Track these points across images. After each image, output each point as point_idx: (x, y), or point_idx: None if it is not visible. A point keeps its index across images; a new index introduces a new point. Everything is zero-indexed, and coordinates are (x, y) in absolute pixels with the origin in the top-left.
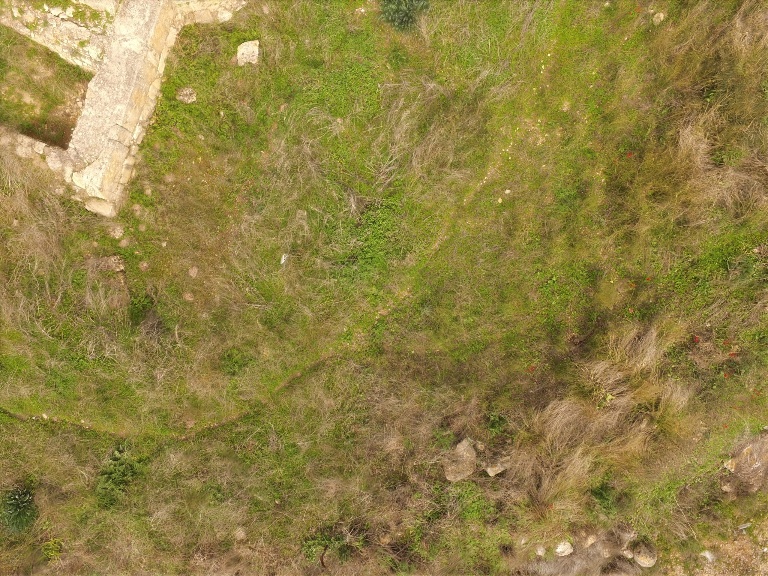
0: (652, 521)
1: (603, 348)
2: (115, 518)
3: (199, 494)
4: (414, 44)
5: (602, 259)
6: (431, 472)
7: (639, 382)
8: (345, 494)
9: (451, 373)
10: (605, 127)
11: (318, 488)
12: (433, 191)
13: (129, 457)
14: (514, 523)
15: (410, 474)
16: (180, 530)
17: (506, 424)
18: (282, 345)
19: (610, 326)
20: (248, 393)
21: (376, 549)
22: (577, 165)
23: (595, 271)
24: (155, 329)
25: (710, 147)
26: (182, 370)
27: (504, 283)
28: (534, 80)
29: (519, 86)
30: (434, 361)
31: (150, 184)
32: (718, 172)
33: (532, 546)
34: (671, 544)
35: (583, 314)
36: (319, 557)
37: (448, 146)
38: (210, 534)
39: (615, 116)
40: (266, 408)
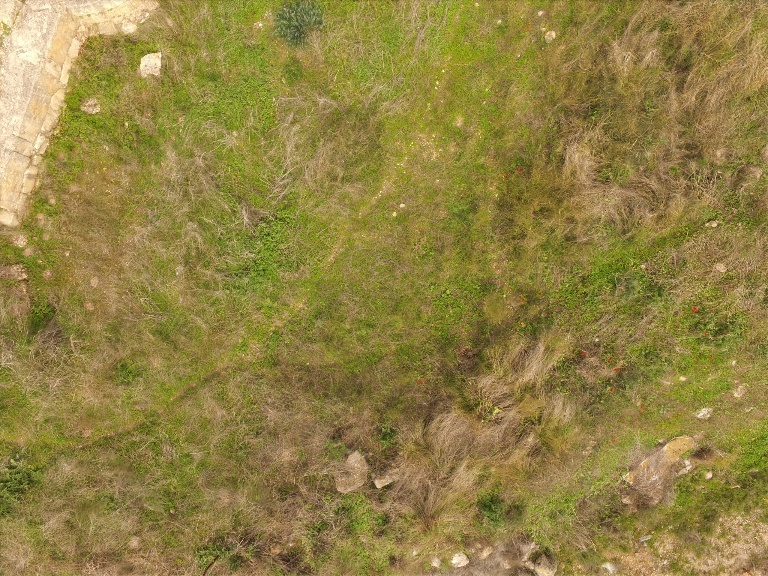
0: (553, 533)
1: (489, 362)
2: (11, 526)
3: (93, 503)
4: (309, 59)
5: (495, 273)
6: (323, 483)
7: (522, 396)
8: (233, 505)
9: (345, 385)
10: (497, 143)
11: (210, 498)
12: (326, 204)
13: (25, 465)
14: (400, 535)
15: (301, 485)
16: (70, 539)
17: (397, 436)
18: (177, 356)
19: (499, 340)
20: (143, 403)
21: (265, 560)
22: (470, 180)
23: (488, 285)
24: (52, 338)
25: (597, 164)
26: (79, 379)
27: (398, 296)
28: (428, 96)
29: (413, 101)
30: (328, 373)
31: (54, 194)
32: (604, 189)
33: (426, 557)
34: (572, 556)
35: (476, 327)
36: (210, 567)
37: (336, 161)
38: (104, 543)
39: (505, 132)
40: (161, 418)
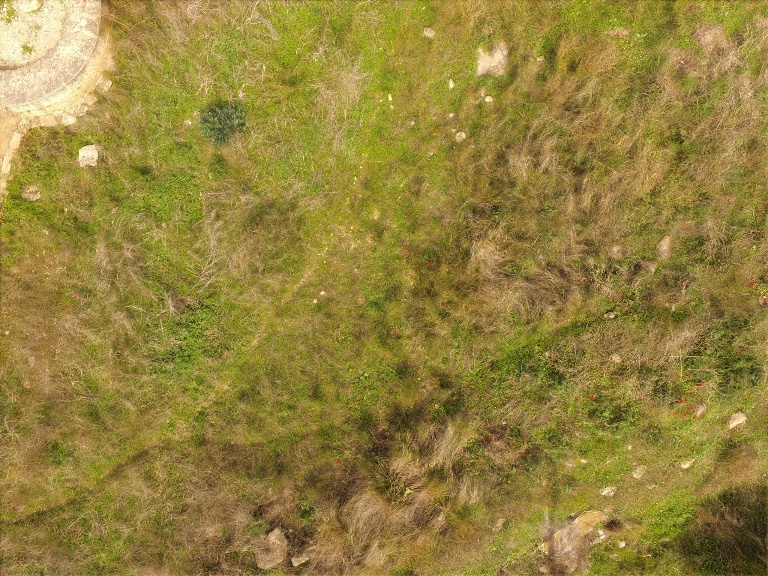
0: None
1: (399, 446)
2: None
3: None
4: (234, 156)
5: (410, 357)
6: (245, 559)
7: (429, 480)
8: None
9: (267, 464)
10: (410, 236)
11: None
12: (249, 293)
13: None
14: None
15: (222, 562)
16: None
17: None
18: (106, 436)
19: (412, 423)
20: (74, 481)
21: None
22: (387, 270)
23: (404, 368)
24: None
25: (502, 259)
26: (13, 457)
27: (318, 379)
28: (346, 191)
29: (332, 196)
30: (251, 452)
31: None
32: (508, 283)
33: None
34: None
35: (393, 409)
36: None
37: (256, 256)
38: None
39: (416, 228)
40: (91, 495)
